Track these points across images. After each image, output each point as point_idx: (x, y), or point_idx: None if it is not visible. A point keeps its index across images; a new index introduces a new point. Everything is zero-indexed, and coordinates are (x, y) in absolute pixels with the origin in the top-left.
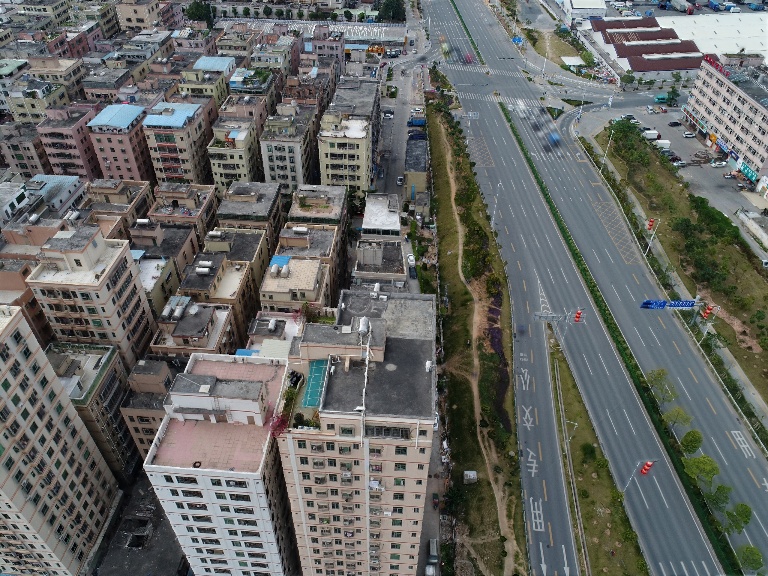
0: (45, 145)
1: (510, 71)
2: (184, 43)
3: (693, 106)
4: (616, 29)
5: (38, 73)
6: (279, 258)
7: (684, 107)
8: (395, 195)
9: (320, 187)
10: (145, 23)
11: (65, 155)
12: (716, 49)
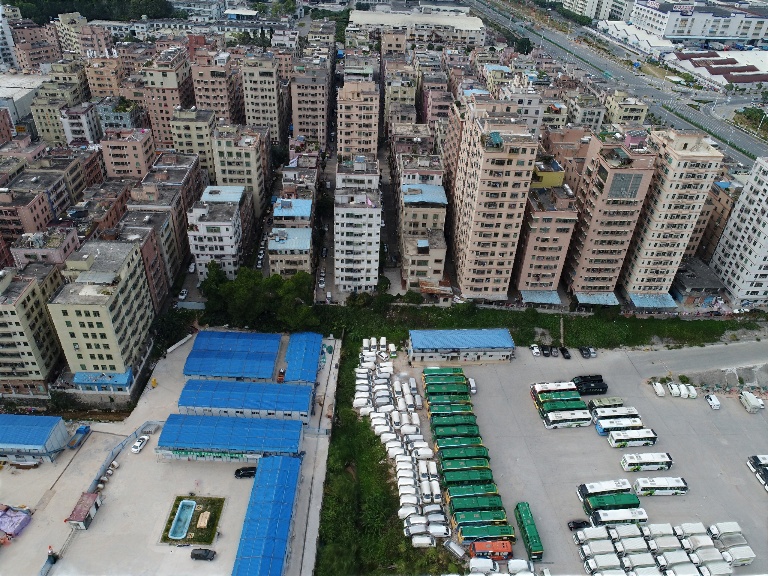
0: (432, 114)
1: None
2: (455, 58)
3: None
4: (699, 58)
5: (396, 72)
6: None
7: None
8: None
9: None
10: (401, 48)
11: None
12: None
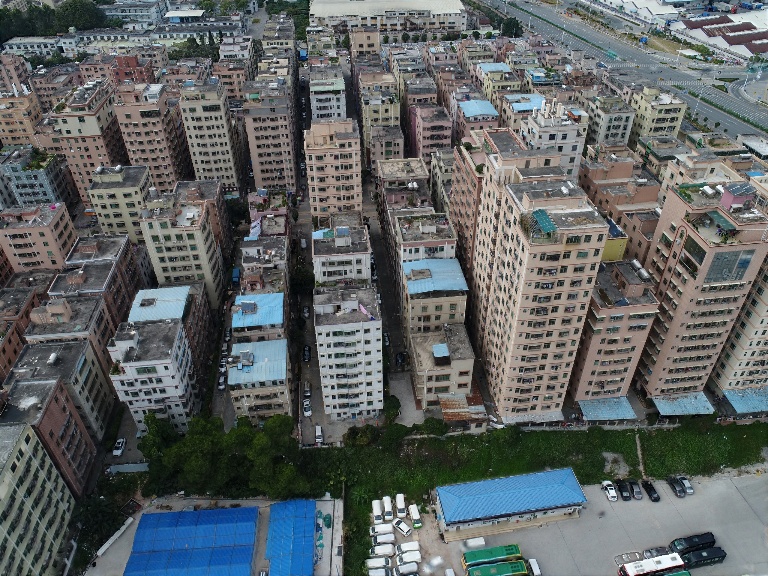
0: (424, 138)
1: (651, 64)
2: (441, 57)
3: None
4: (711, 25)
5: (373, 86)
6: (752, 174)
7: None
8: (760, 134)
9: (705, 134)
10: (375, 47)
11: (437, 145)
12: None
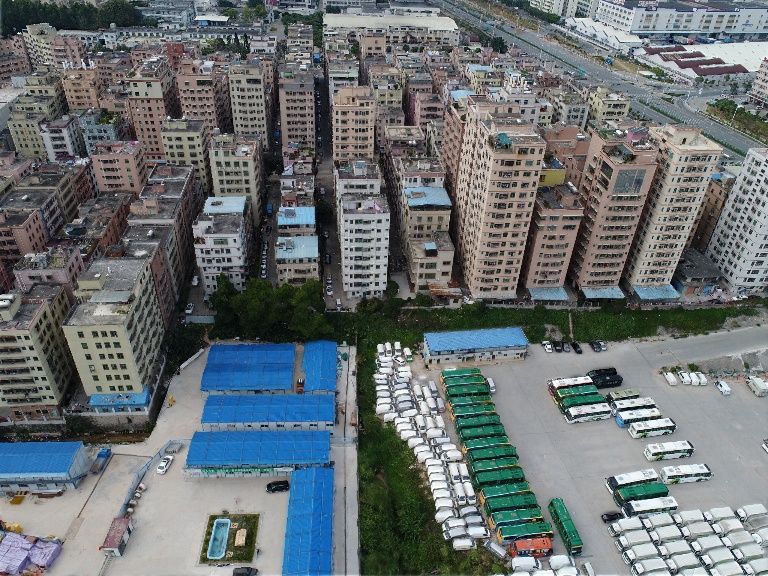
0: (421, 116)
1: (614, 80)
2: (436, 59)
3: (757, 90)
4: (667, 52)
5: (381, 75)
6: None
7: (749, 92)
8: None
9: None
10: (381, 50)
11: None
12: (735, 63)
